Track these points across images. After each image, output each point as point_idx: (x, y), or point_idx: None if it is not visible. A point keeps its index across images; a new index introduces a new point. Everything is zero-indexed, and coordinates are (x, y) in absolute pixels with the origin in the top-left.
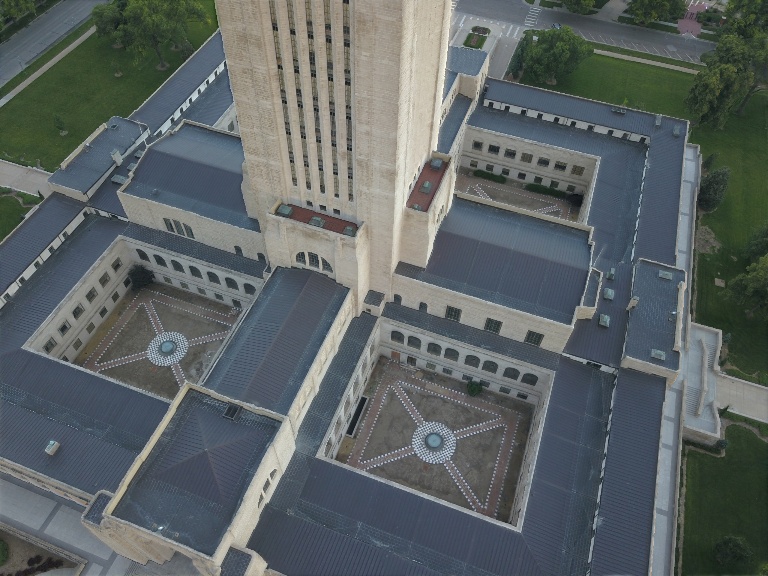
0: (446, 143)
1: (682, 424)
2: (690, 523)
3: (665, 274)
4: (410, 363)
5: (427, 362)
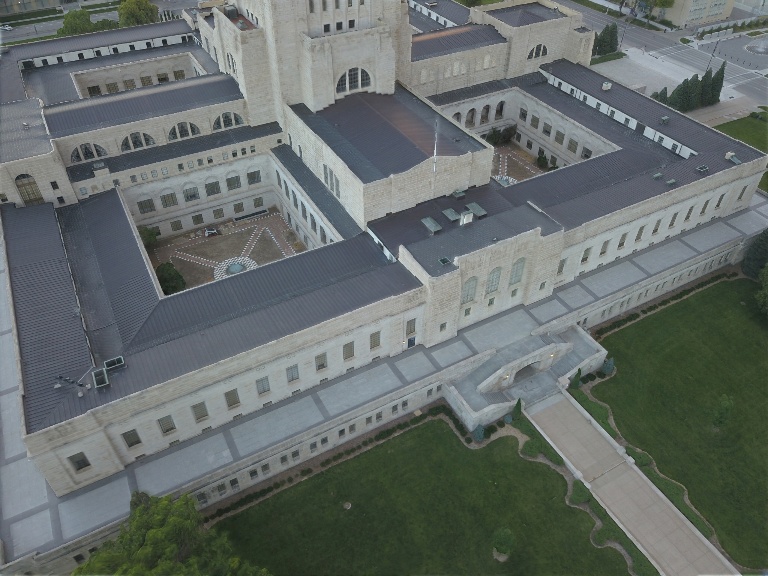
0: None
1: None
2: None
3: None
4: None
5: None
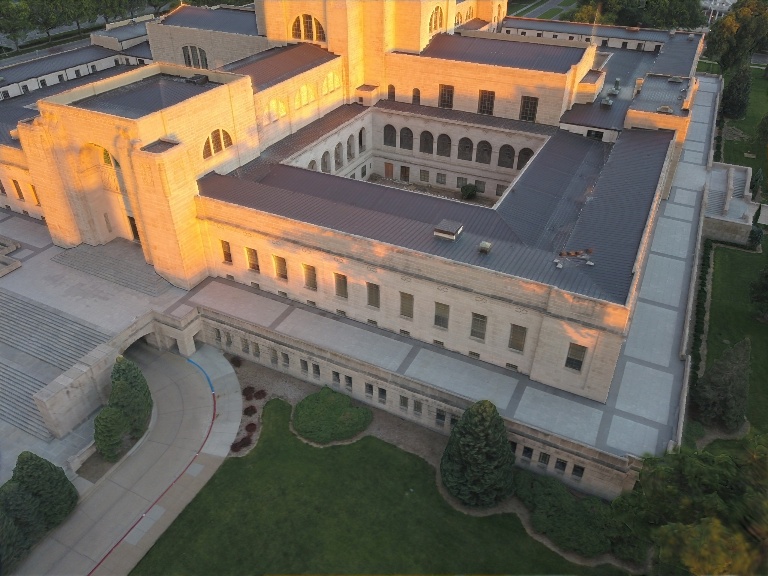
0: None
1: (703, 205)
2: (719, 292)
3: (674, 78)
4: (404, 179)
5: (420, 169)
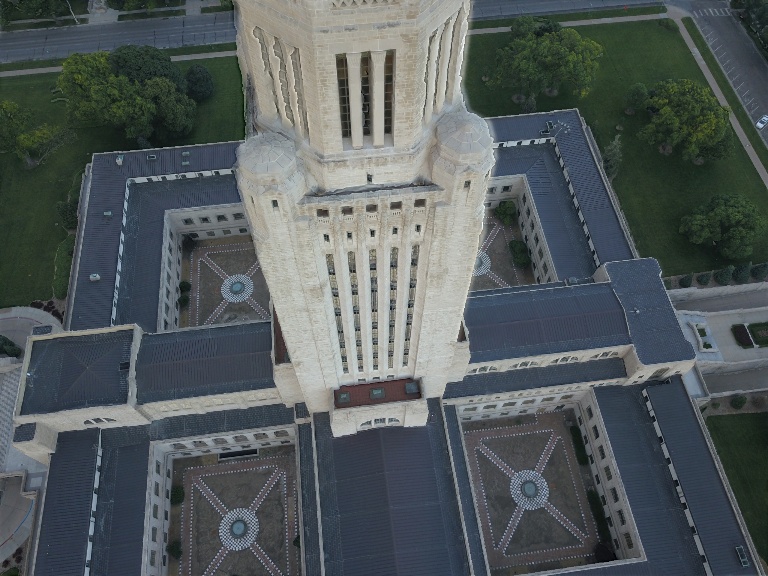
0: (537, 381)
1: None
2: None
3: None
4: None
5: None
